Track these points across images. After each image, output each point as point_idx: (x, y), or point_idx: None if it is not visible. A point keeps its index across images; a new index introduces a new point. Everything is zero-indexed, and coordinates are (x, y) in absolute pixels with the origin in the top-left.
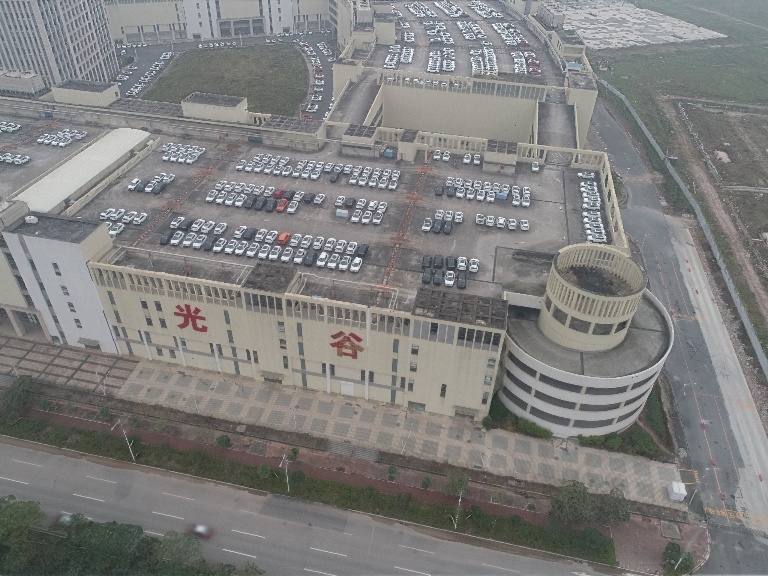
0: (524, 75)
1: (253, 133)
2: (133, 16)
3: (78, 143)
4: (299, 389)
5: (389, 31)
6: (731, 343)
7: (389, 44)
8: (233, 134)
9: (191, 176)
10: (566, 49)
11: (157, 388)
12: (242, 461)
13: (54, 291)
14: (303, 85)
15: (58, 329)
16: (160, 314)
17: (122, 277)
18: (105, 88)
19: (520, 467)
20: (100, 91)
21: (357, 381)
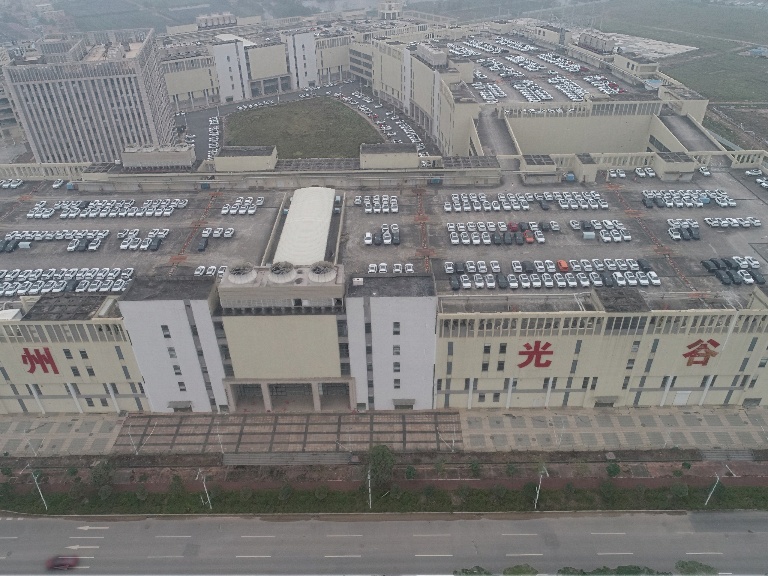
0: (631, 94)
1: (436, 176)
2: (169, 86)
3: (263, 209)
4: (631, 408)
5: (467, 70)
6: None
7: (468, 82)
8: (413, 179)
9: (411, 223)
10: (642, 68)
11: (498, 434)
12: None
13: (381, 353)
14: (373, 132)
15: (368, 395)
16: (501, 357)
17: (469, 324)
18: (265, 151)
19: None
20: (264, 155)
21: (695, 388)
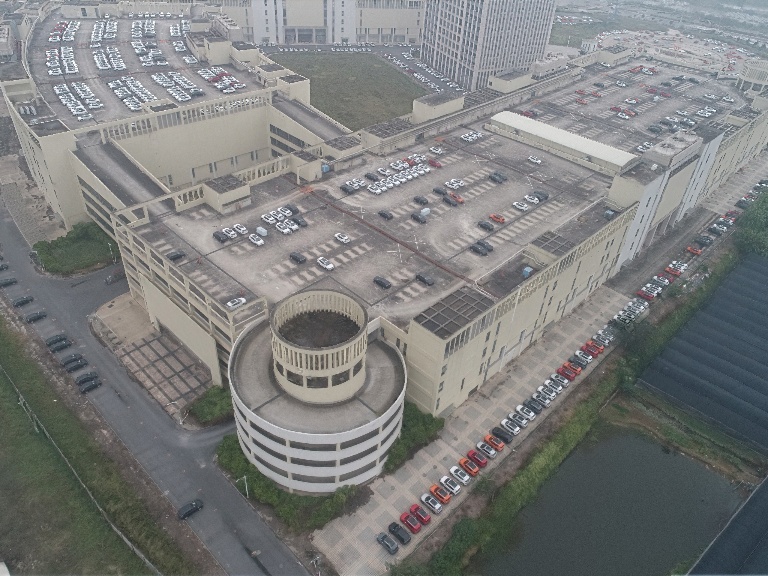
0: (78, 5)
1: None
2: None
3: None
4: None
5: None
6: None
7: None
8: None
9: None
10: None
11: None
12: None
13: None
14: None
15: None
16: None
17: None
18: None
19: None
20: None
21: None
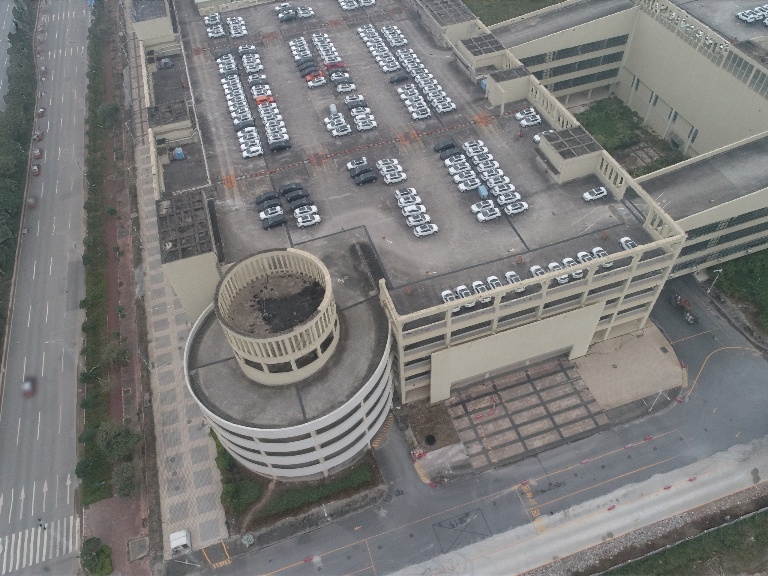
0: None
1: (415, 4)
2: None
3: None
4: None
5: None
6: (510, 575)
7: None
8: None
9: (323, 20)
10: None
11: None
12: (108, 232)
13: None
14: None
15: None
16: None
17: None
18: None
19: (166, 396)
20: None
21: None
